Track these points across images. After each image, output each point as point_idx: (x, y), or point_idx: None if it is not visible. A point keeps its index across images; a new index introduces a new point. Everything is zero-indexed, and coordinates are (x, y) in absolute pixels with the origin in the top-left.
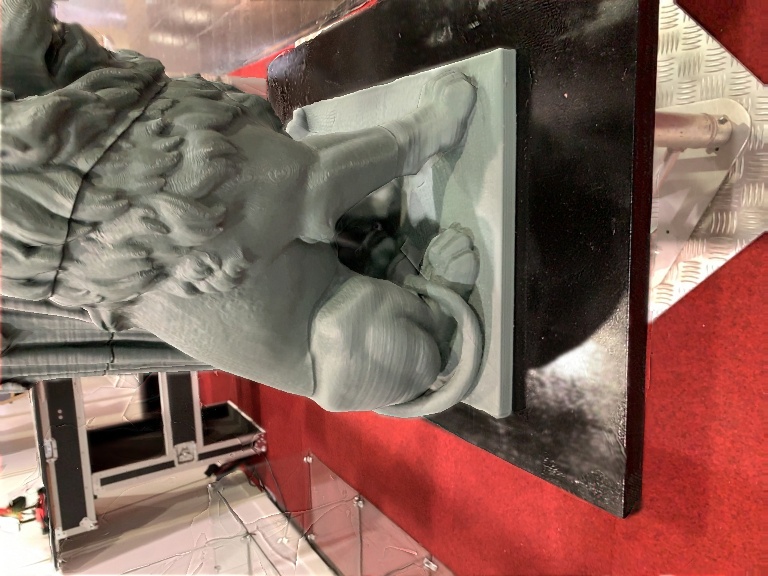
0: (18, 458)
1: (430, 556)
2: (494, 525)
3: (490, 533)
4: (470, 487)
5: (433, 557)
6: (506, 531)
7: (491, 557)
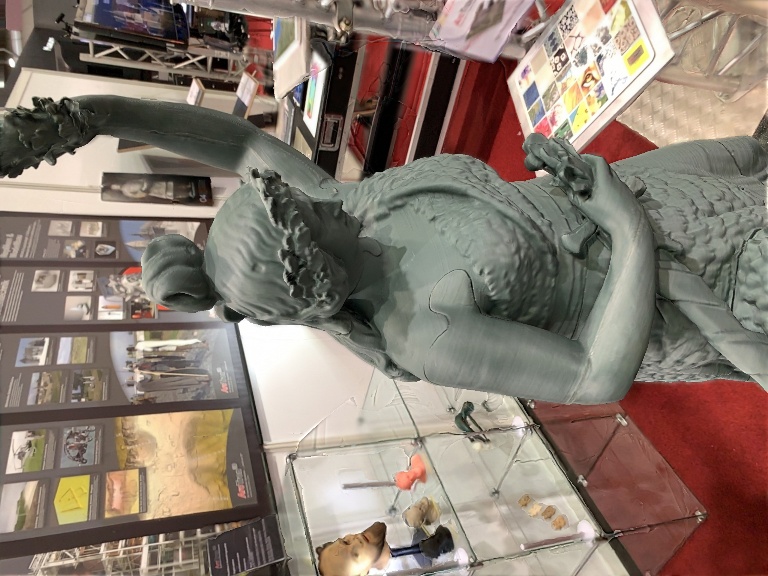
0: (233, 183)
1: (625, 414)
2: (711, 425)
3: (703, 428)
4: (700, 389)
5: (627, 416)
6: (722, 434)
7: (694, 443)
